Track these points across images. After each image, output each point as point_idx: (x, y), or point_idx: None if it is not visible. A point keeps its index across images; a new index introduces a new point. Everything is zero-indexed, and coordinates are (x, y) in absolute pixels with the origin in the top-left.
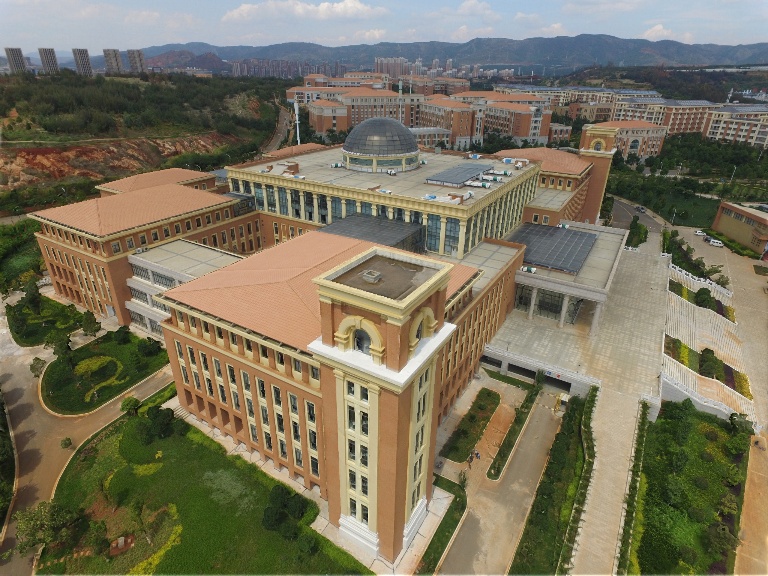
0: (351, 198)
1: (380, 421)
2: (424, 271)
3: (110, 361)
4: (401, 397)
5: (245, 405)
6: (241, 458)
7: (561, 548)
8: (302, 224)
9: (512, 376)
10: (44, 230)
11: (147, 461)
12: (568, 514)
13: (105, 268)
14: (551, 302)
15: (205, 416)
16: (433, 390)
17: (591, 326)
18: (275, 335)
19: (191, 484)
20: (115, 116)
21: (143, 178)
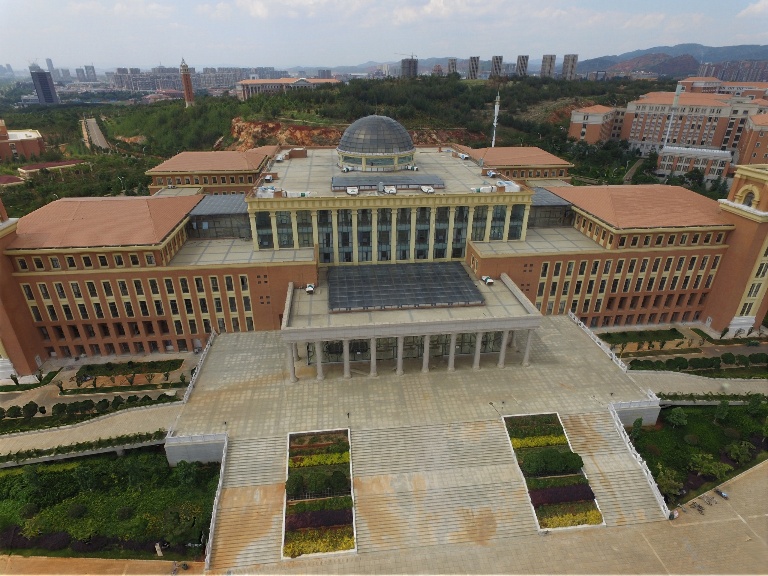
0: None
1: None
2: None
3: None
4: None
5: None
6: None
7: None
8: None
9: None
10: None
11: None
12: None
13: None
14: None
15: None
16: None
17: None
18: None
19: None
20: None
21: (264, 148)
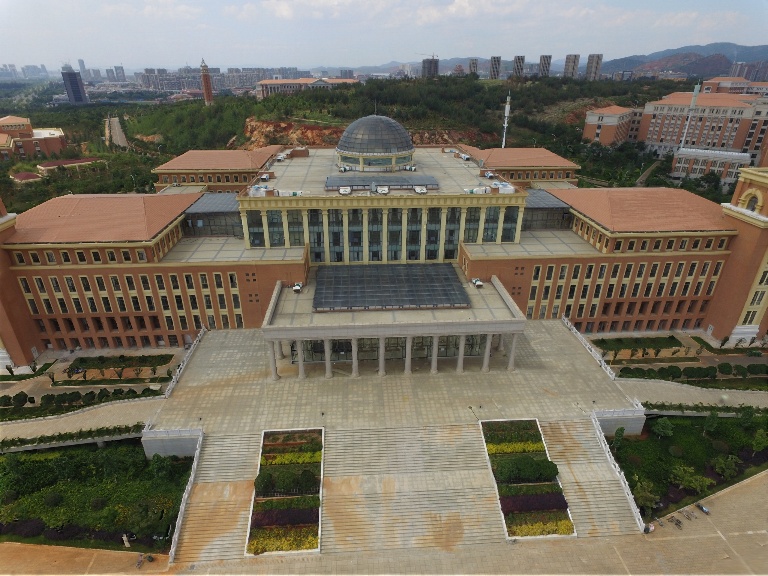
0: None
1: None
2: None
3: None
4: None
5: None
6: None
7: None
8: None
9: None
10: None
11: None
12: None
13: None
14: None
15: None
16: None
17: None
18: None
19: None
20: None
21: (271, 148)
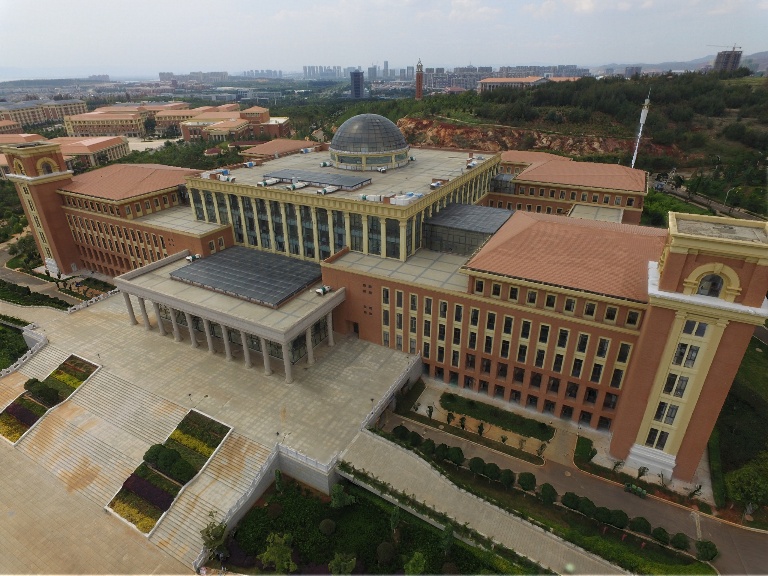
0: None
1: None
2: None
3: None
4: None
5: None
6: None
7: None
8: None
9: None
10: None
11: None
12: None
13: None
14: None
15: None
16: (34, 202)
17: None
18: None
19: None
20: None
21: None
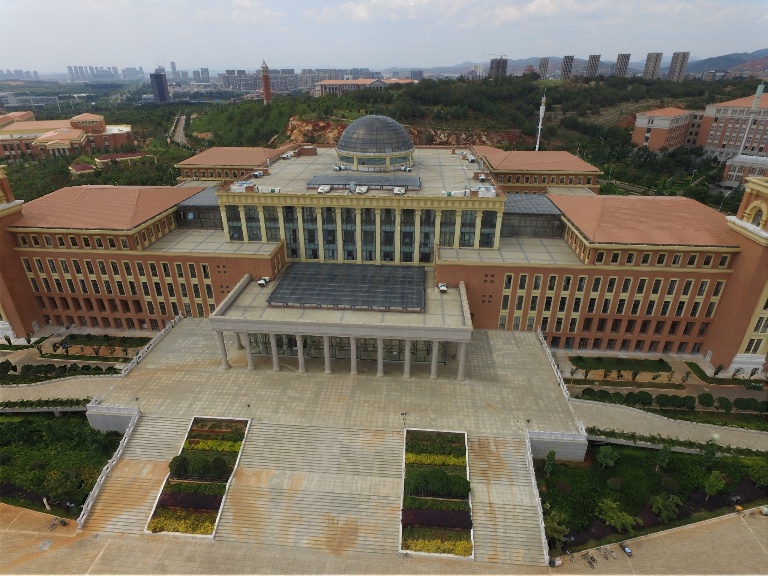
0: None
1: None
2: None
3: None
4: None
5: None
6: None
7: None
8: None
9: None
10: None
11: None
12: None
13: None
14: None
15: None
16: None
17: None
18: None
19: None
20: None
21: None
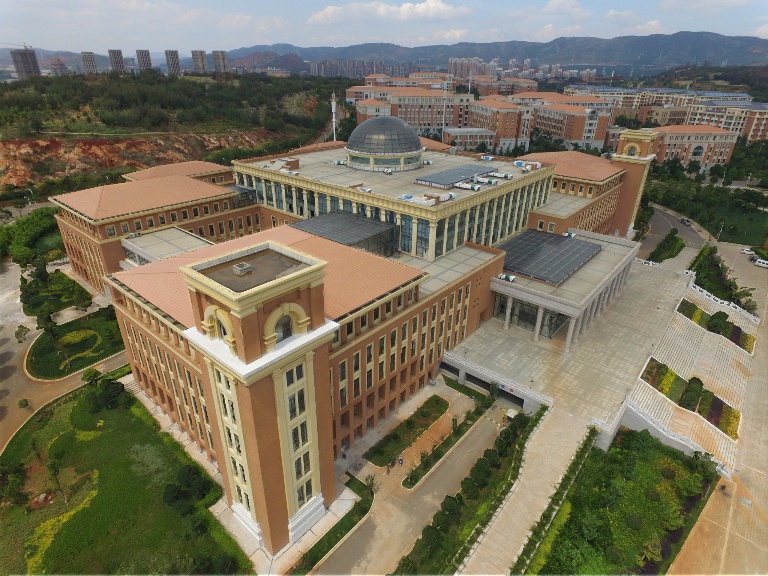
0: (334, 195)
1: (242, 411)
2: (298, 267)
3: (93, 335)
4: (254, 389)
5: (172, 386)
6: (169, 436)
7: (448, 567)
8: (294, 219)
9: (469, 386)
10: (62, 212)
11: (89, 428)
12: (468, 534)
13: (99, 249)
14: (531, 313)
15: (150, 393)
16: (313, 387)
17: (565, 342)
18: (184, 320)
19: (118, 454)
20: (171, 112)
21: (163, 169)
